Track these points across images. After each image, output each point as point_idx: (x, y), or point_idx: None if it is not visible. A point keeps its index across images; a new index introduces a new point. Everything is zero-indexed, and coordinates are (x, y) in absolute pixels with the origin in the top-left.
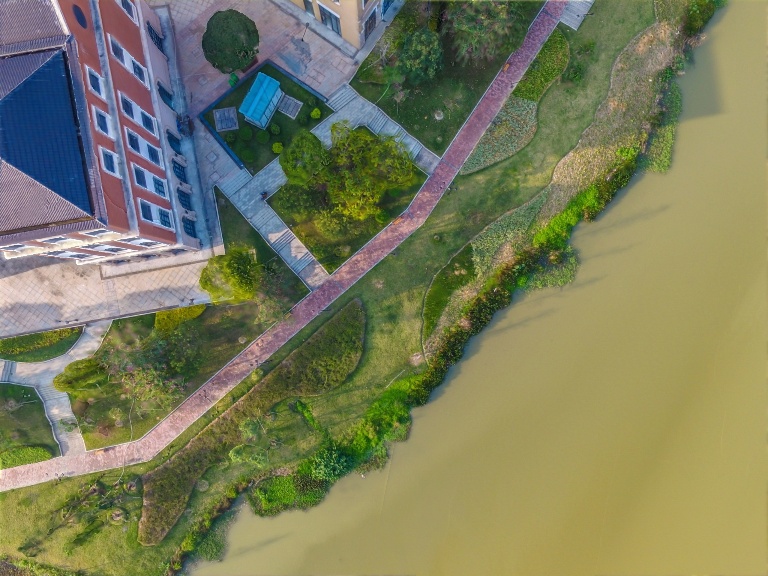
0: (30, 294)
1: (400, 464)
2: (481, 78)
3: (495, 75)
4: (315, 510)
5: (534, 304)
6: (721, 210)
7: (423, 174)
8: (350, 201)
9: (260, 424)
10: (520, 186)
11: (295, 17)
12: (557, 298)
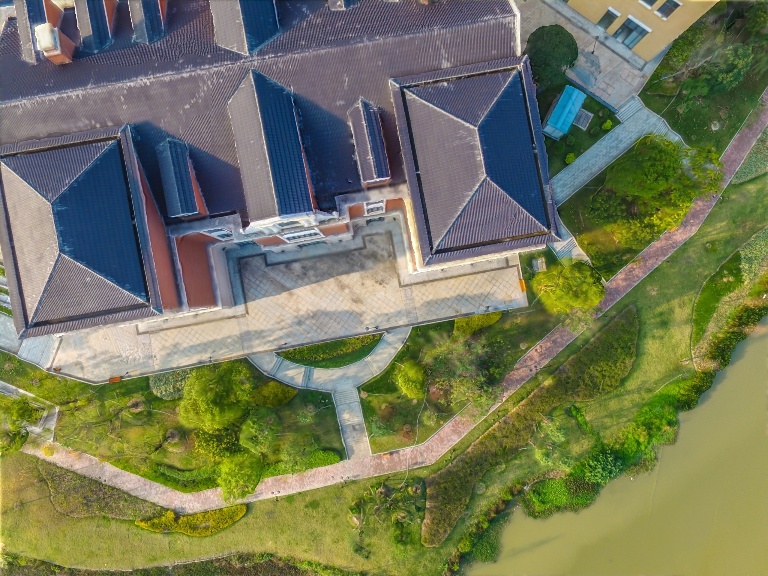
0: (331, 302)
1: (668, 467)
2: (754, 89)
3: (766, 86)
4: (586, 512)
5: None
6: None
7: None
8: (671, 211)
9: (538, 428)
10: None
11: (585, 30)
12: None
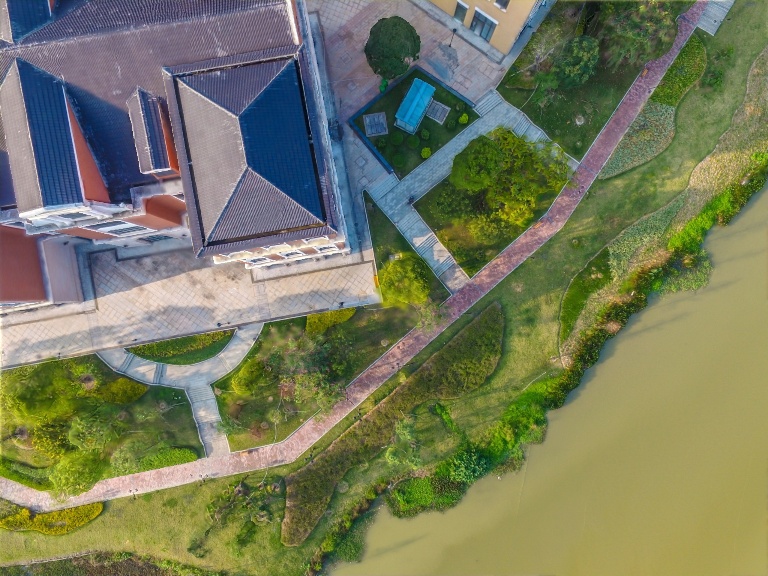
0: (182, 297)
1: (536, 466)
2: (620, 83)
3: (633, 80)
4: (452, 512)
5: (668, 308)
6: None
7: None
8: (513, 206)
9: None
10: (657, 190)
11: (442, 23)
12: (691, 302)
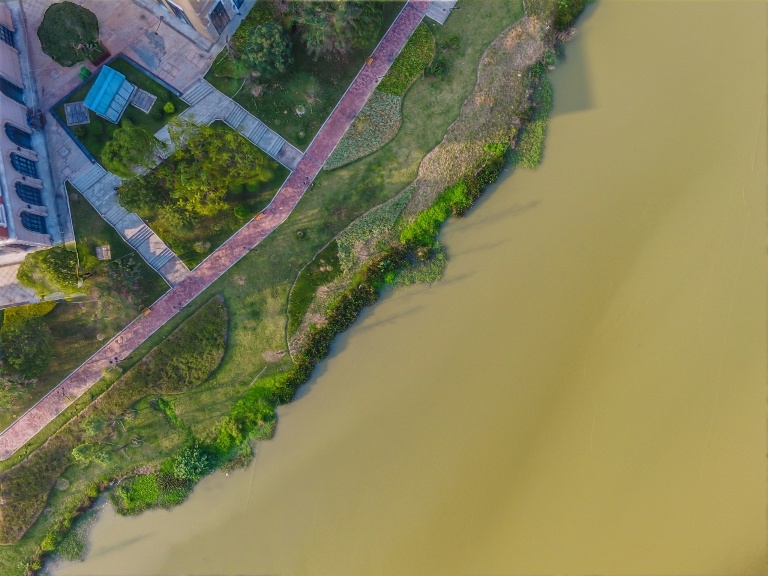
0: None
1: (266, 462)
2: (344, 72)
3: (359, 69)
4: (179, 509)
5: (402, 301)
6: (592, 206)
7: (286, 169)
8: (188, 196)
9: (120, 422)
10: (385, 182)
11: (149, 10)
12: (425, 295)
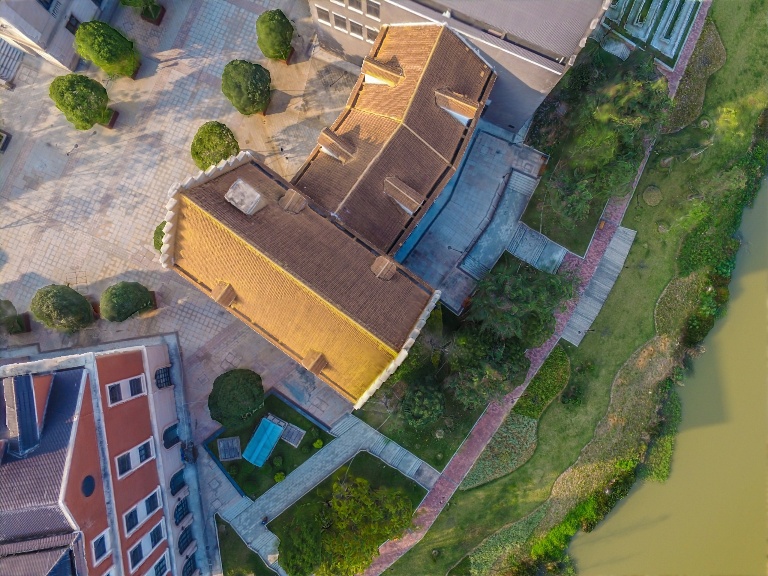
0: None
1: None
2: None
3: None
4: None
5: None
6: (720, 521)
7: (423, 489)
8: None
9: None
10: (519, 501)
11: None
12: None
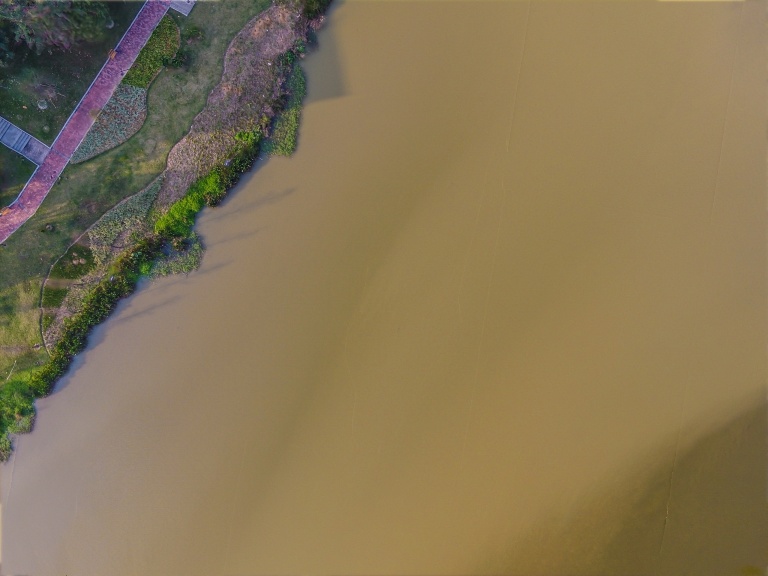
0: None
1: (26, 456)
2: (87, 66)
3: (104, 63)
4: None
5: (159, 292)
6: (349, 192)
7: (32, 164)
8: None
9: None
10: (133, 173)
11: None
12: (183, 285)
